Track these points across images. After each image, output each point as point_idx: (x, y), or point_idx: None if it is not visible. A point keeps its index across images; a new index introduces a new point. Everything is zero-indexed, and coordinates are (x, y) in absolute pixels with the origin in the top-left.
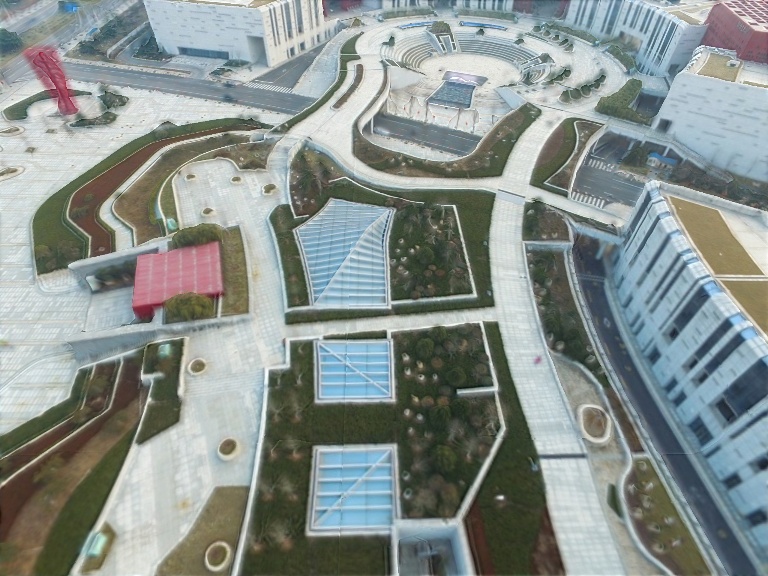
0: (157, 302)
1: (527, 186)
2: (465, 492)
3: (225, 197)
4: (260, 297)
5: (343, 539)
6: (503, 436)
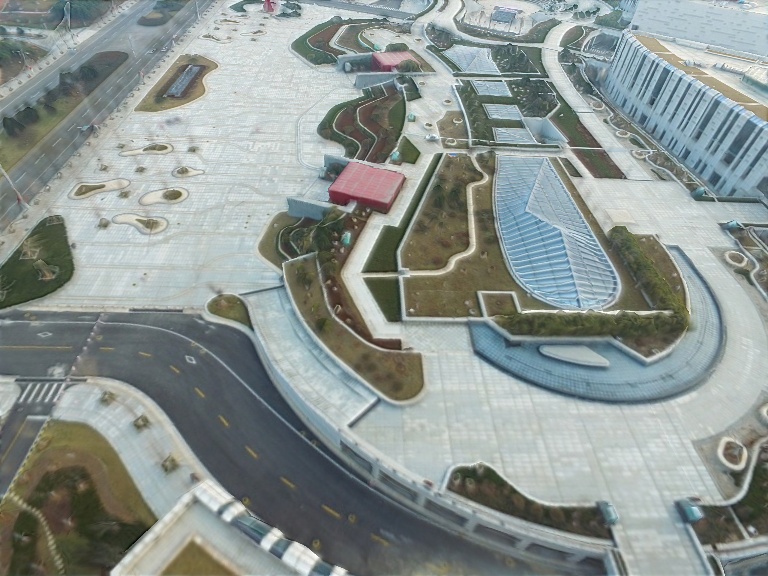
0: (393, 65)
1: (558, 47)
2: (548, 113)
3: (396, 42)
4: (437, 70)
5: (504, 119)
6: (560, 106)
